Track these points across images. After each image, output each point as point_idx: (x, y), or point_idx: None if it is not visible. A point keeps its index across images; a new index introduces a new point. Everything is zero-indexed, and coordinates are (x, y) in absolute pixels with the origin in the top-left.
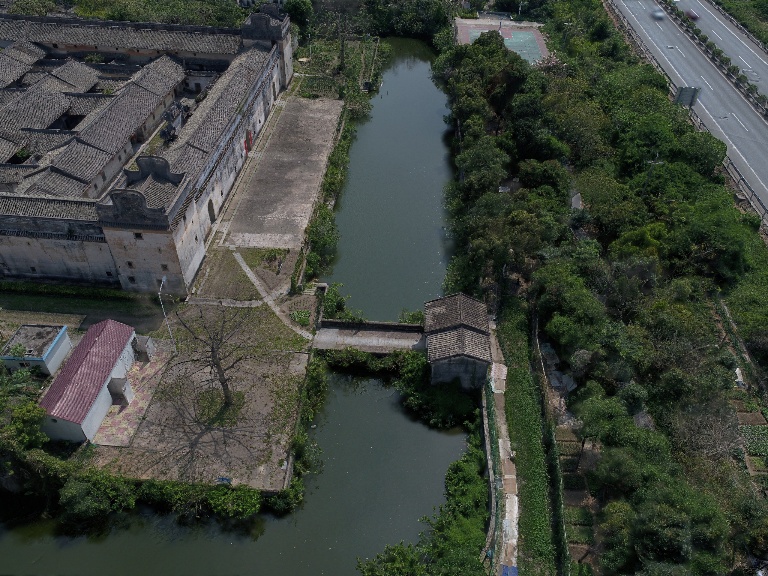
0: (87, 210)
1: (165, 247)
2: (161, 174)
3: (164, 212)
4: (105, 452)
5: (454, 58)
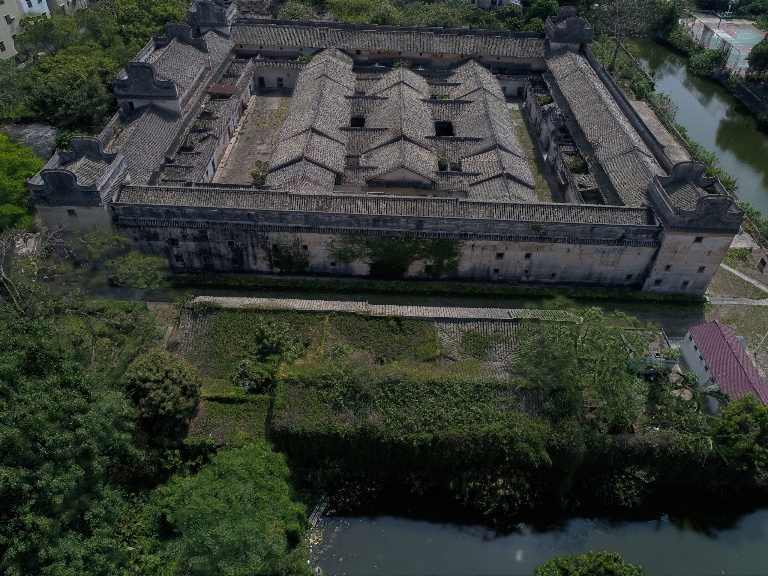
0: (622, 216)
1: (717, 250)
2: (692, 179)
3: (742, 216)
4: None
5: (754, 57)
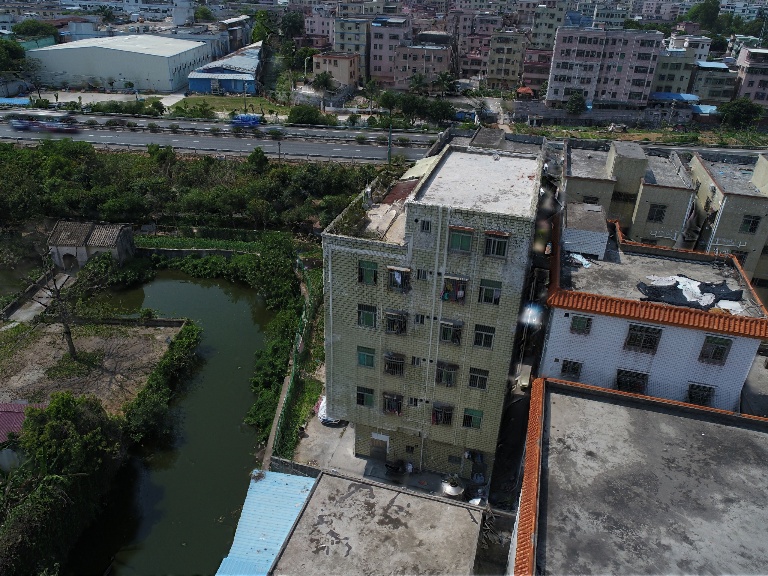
0: None
1: None
2: None
3: None
4: None
5: None
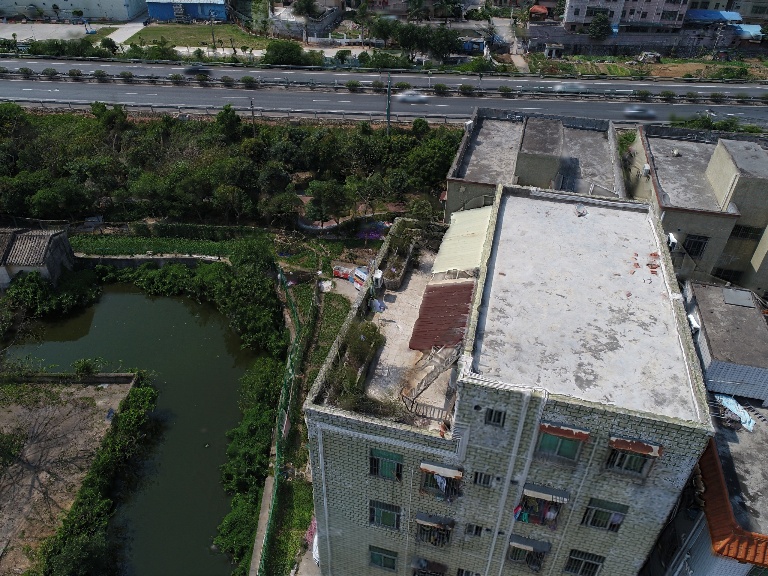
0: None
1: None
2: None
3: None
4: (6, 566)
5: None
